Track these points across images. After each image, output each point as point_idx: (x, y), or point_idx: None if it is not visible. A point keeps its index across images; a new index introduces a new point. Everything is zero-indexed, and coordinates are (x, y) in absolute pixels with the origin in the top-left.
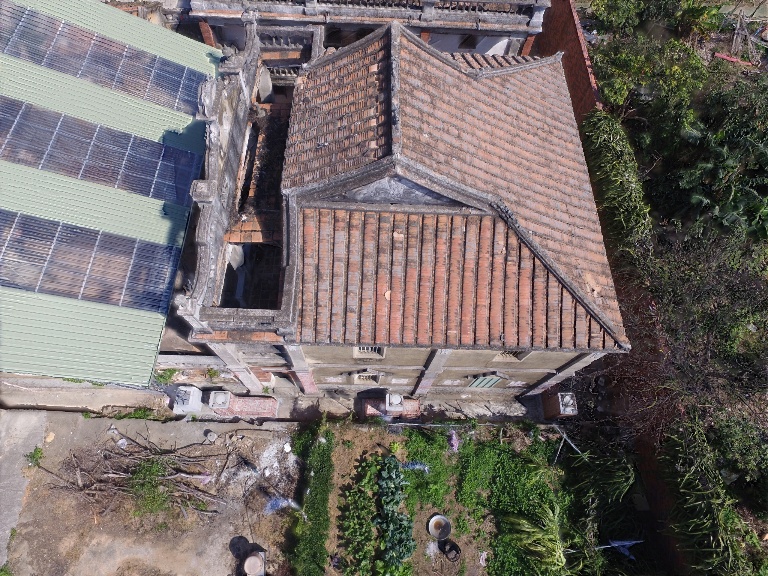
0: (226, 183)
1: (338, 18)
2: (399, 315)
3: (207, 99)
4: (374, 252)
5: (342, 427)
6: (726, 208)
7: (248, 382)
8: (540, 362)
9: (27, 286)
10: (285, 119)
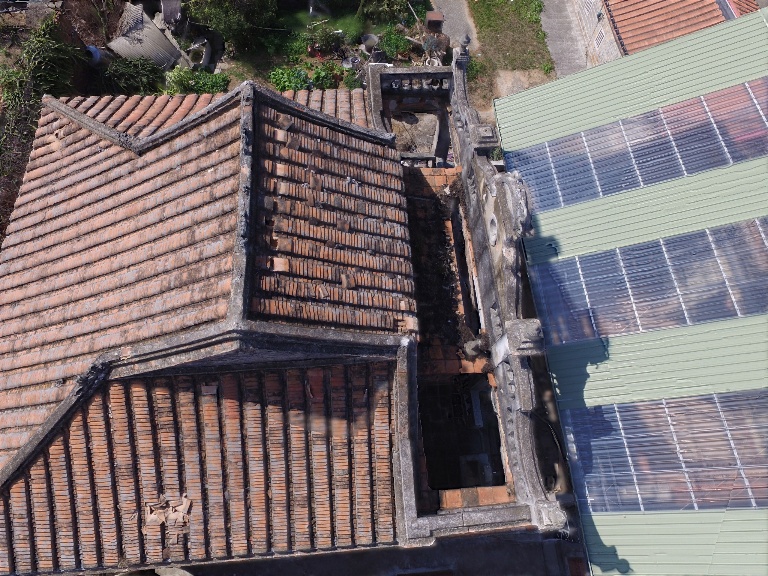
0: None
1: None
2: None
3: (512, 180)
4: None
5: None
6: None
7: None
8: None
9: (630, 121)
10: (433, 341)
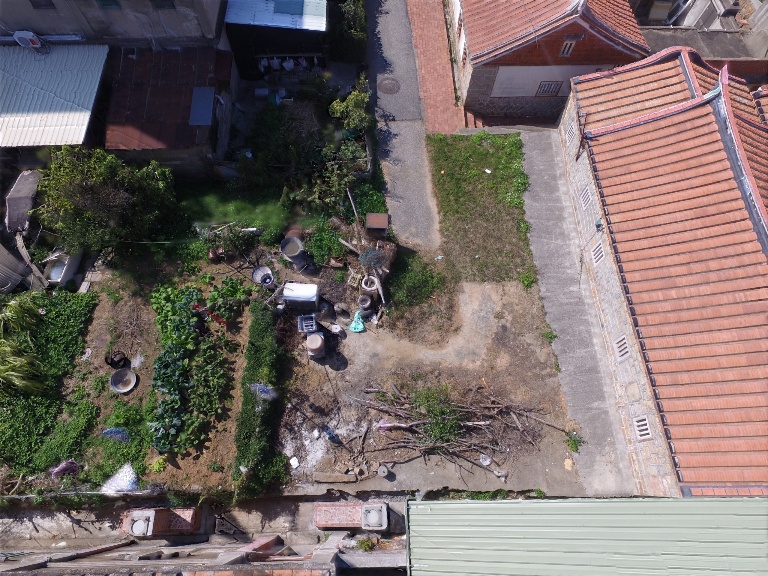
0: None
1: None
2: None
3: None
4: None
5: None
6: None
7: None
8: None
9: None
10: None
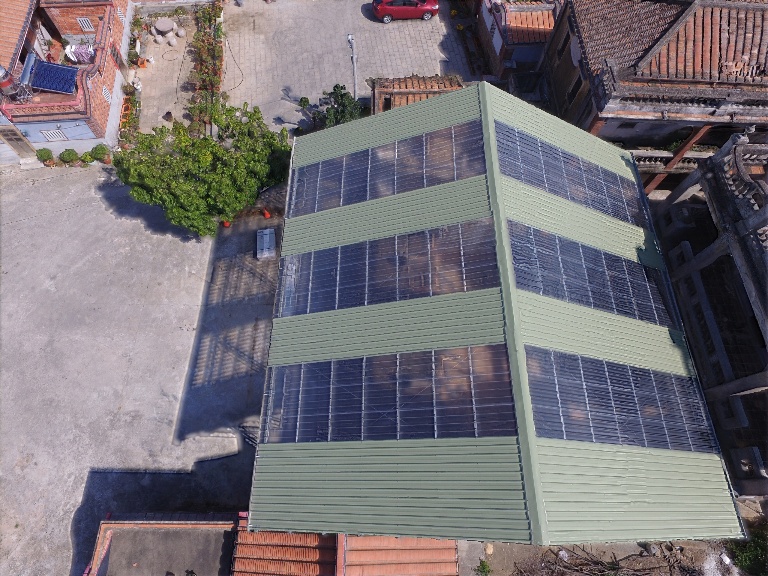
0: None
1: (743, 118)
2: None
3: None
4: None
5: None
6: None
7: None
8: None
9: (639, 441)
10: None
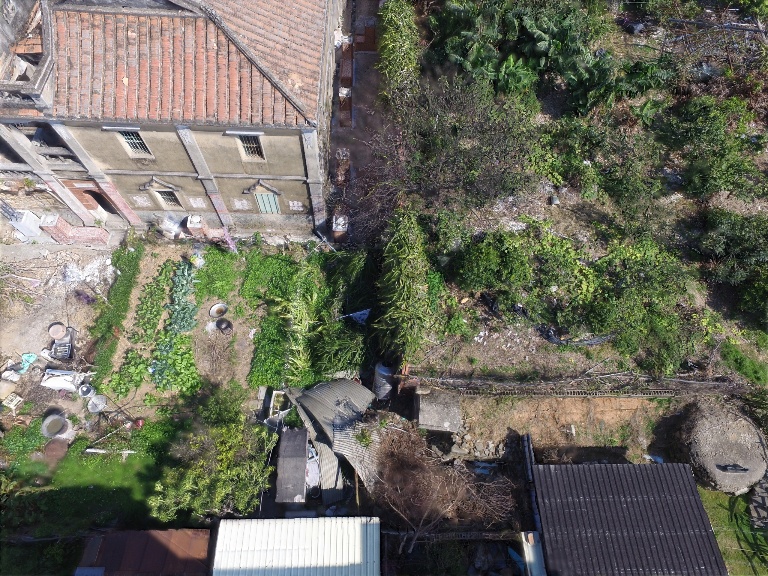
0: (12, 6)
1: None
2: (135, 97)
3: None
4: (114, 47)
5: (152, 242)
6: (476, 64)
7: (71, 203)
8: (282, 162)
9: None
10: None
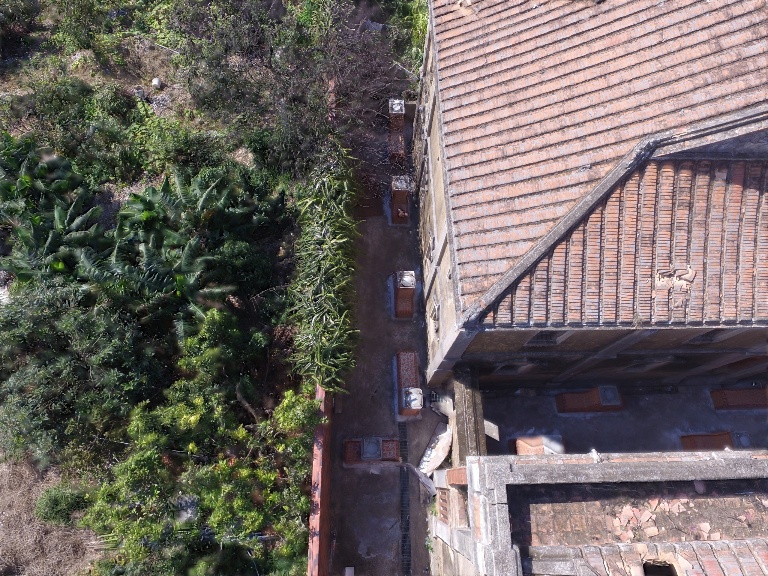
0: None
1: None
2: None
3: None
4: None
5: None
6: None
7: None
8: None
9: None
10: None
